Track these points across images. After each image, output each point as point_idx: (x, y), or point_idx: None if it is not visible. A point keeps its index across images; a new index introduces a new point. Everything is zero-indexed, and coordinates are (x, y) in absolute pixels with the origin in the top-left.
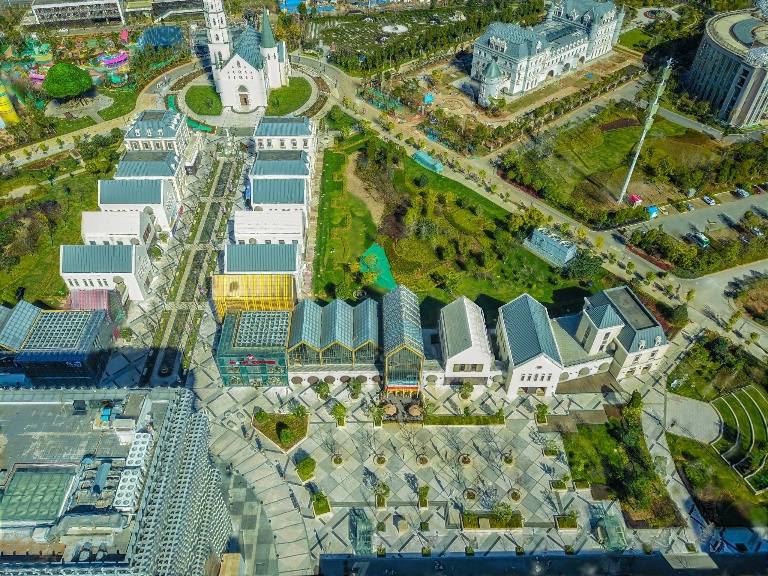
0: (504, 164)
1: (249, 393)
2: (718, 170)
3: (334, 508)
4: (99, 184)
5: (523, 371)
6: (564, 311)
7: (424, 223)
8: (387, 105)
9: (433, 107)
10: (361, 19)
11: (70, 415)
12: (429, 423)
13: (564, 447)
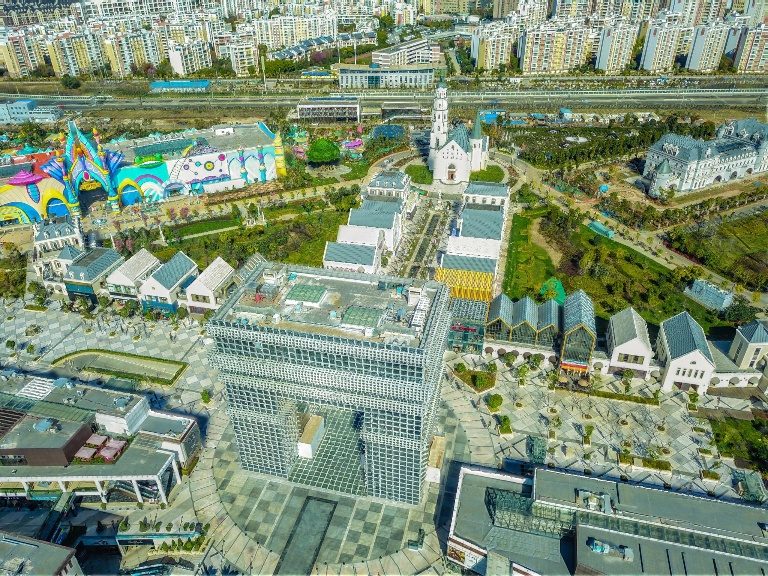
0: (670, 236)
1: (451, 355)
2: None
3: (515, 433)
4: (351, 211)
5: (679, 365)
6: None
7: None
8: (568, 189)
9: (607, 194)
10: (547, 131)
11: (376, 289)
12: (594, 394)
13: (712, 429)
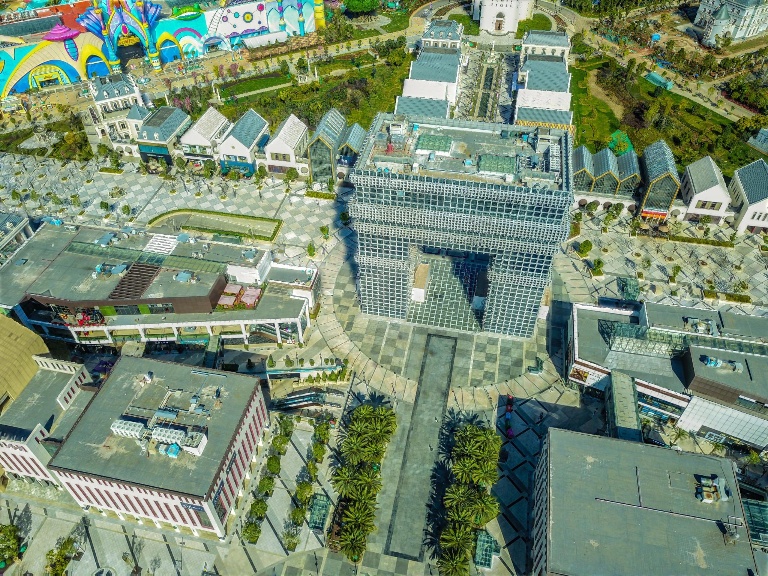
0: (730, 86)
1: None
2: None
3: (605, 275)
4: (411, 64)
5: (756, 209)
6: None
7: (662, 118)
8: None
9: (660, 44)
10: None
11: (499, 138)
12: (674, 239)
13: None
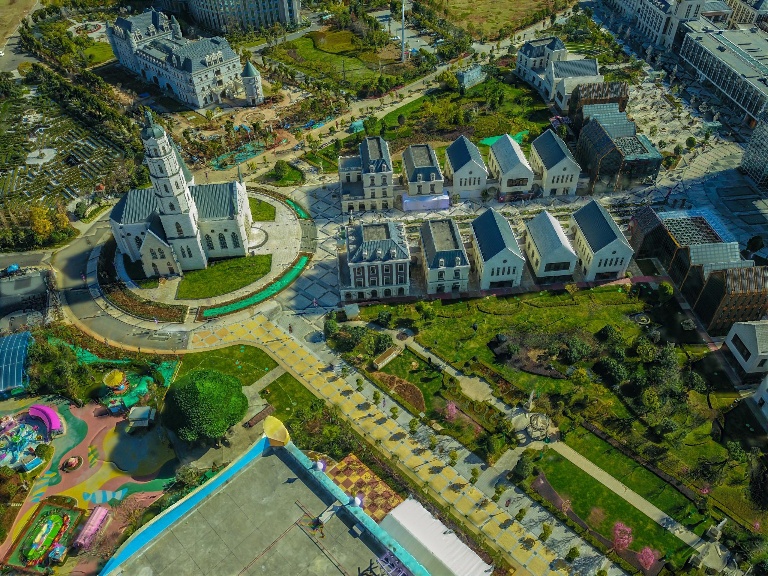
0: None
1: None
2: (376, 25)
3: None
4: (510, 250)
5: None
6: (520, 81)
7: None
8: None
9: None
10: None
11: None
12: None
13: None
